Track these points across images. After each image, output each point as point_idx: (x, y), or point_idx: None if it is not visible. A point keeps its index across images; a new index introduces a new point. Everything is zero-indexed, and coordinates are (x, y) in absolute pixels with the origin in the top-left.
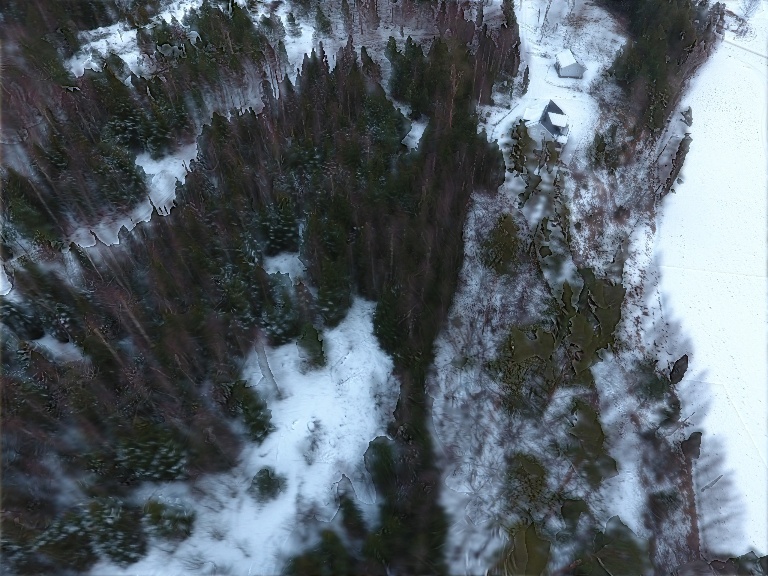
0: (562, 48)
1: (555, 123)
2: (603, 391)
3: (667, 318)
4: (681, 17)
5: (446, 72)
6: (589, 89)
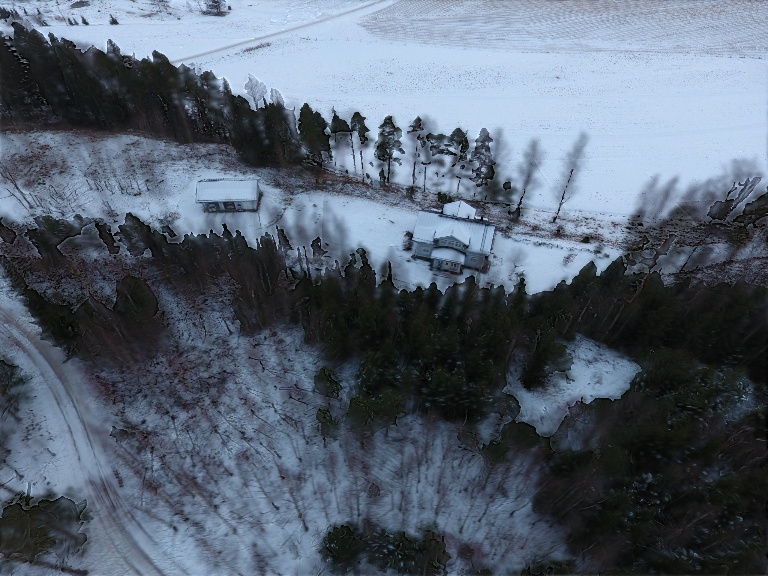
0: (140, 197)
1: (472, 216)
2: (765, 253)
3: (632, 215)
4: (182, 69)
5: (468, 303)
6: (285, 191)
